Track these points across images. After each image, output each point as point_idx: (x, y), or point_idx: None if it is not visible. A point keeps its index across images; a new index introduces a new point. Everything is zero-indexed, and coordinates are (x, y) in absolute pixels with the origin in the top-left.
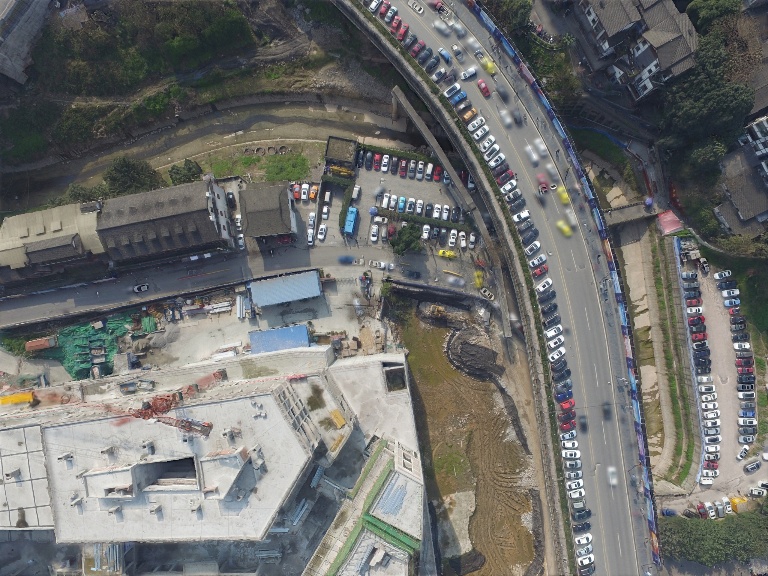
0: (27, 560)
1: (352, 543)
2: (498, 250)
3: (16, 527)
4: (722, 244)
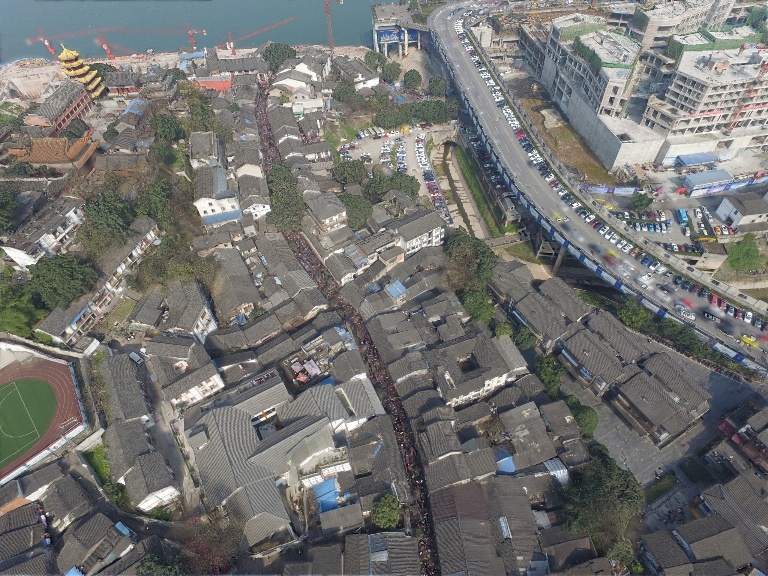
0: None
1: None
2: None
3: None
4: None
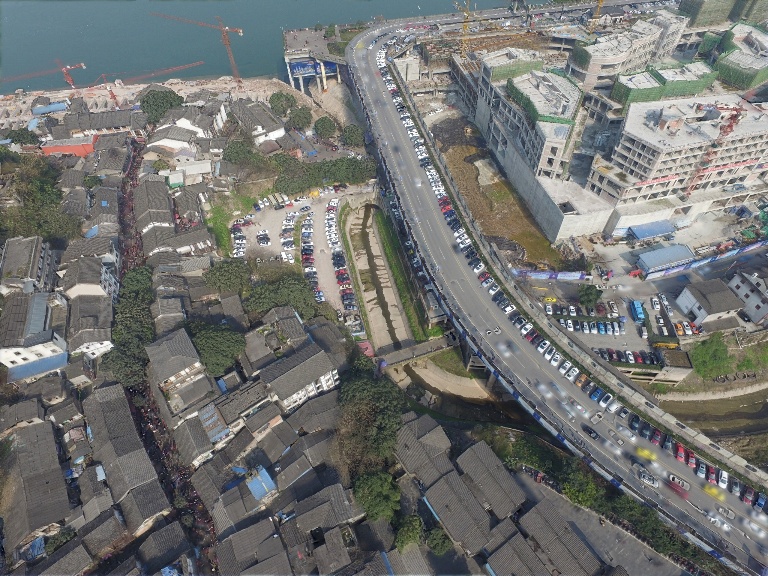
0: None
1: None
2: None
3: (760, 104)
4: None
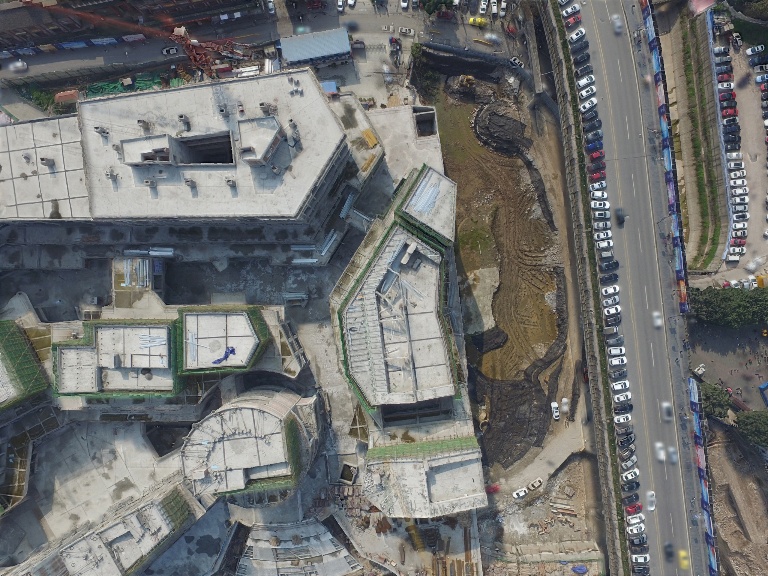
0: (54, 300)
1: (385, 235)
2: (531, 3)
3: (49, 218)
4: (757, 5)
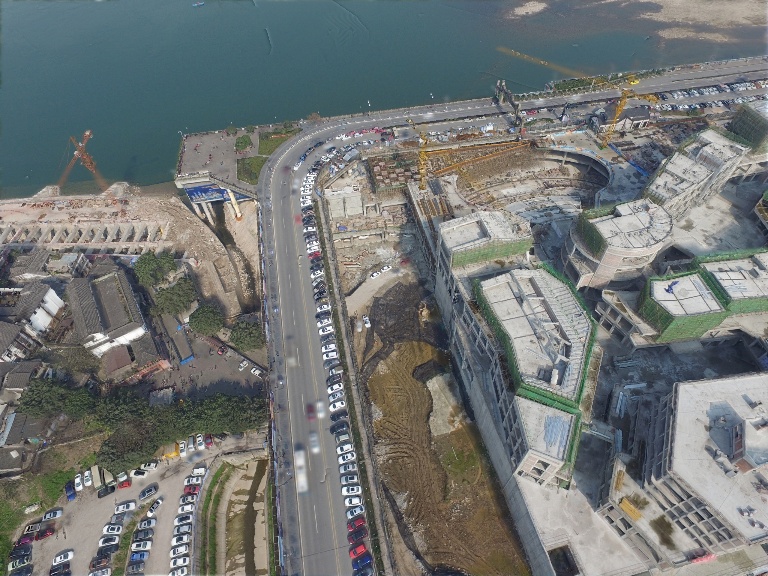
0: None
1: None
2: None
3: None
4: None
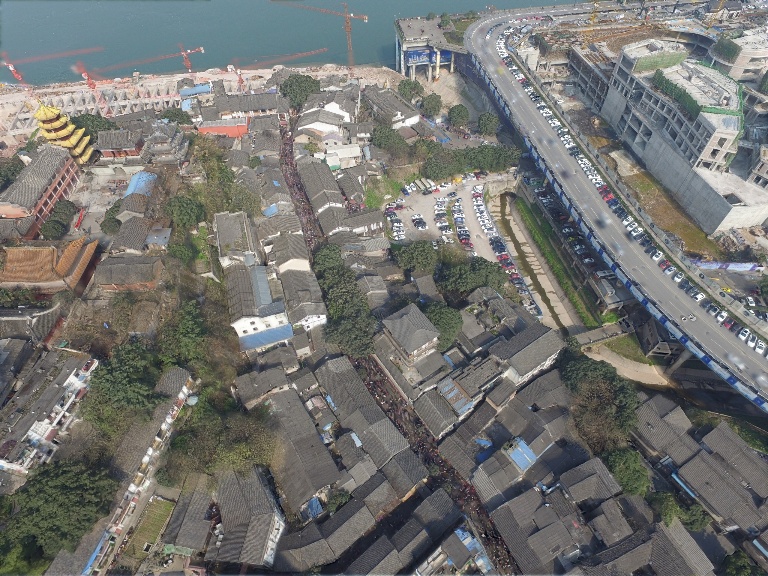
0: None
1: None
2: None
3: None
4: None
